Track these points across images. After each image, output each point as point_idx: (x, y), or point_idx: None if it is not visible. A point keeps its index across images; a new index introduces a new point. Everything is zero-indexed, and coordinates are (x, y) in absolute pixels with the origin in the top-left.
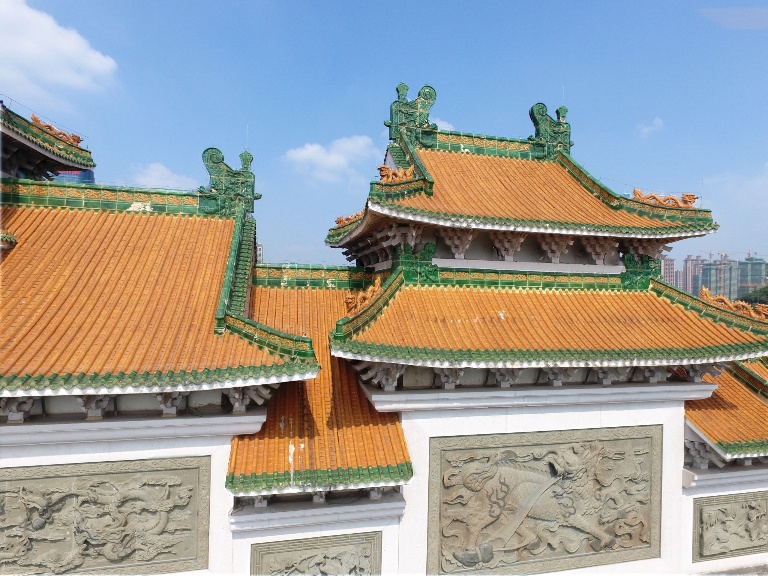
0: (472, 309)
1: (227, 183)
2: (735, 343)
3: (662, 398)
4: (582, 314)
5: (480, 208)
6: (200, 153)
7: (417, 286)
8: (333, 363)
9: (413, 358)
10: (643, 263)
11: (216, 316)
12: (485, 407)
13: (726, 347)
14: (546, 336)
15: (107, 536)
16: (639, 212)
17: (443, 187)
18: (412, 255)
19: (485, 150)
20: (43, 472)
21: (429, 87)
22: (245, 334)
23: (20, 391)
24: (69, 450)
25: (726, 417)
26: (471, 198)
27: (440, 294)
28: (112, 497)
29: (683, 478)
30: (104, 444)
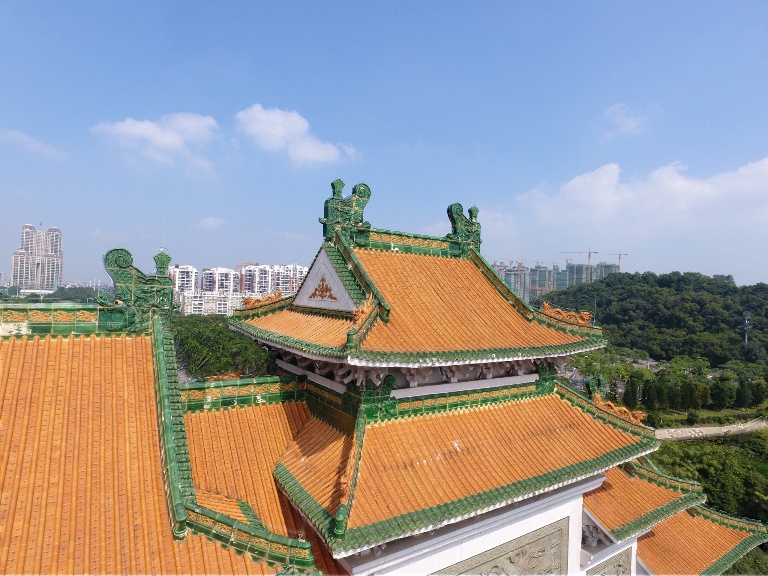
0: (432, 444)
1: (137, 292)
2: (623, 446)
3: (572, 496)
4: (516, 431)
5: (433, 335)
6: (100, 254)
7: (378, 422)
8: (284, 511)
9: (404, 532)
10: (551, 370)
11: (178, 519)
12: (447, 544)
13: (619, 452)
14: (497, 466)
15: None
16: (548, 324)
17: (391, 305)
18: (374, 391)
19: (412, 249)
20: None
21: (364, 185)
22: (216, 535)
23: None
24: None
25: (608, 499)
26: (420, 320)
27: (399, 428)
28: None
29: (581, 558)
30: None
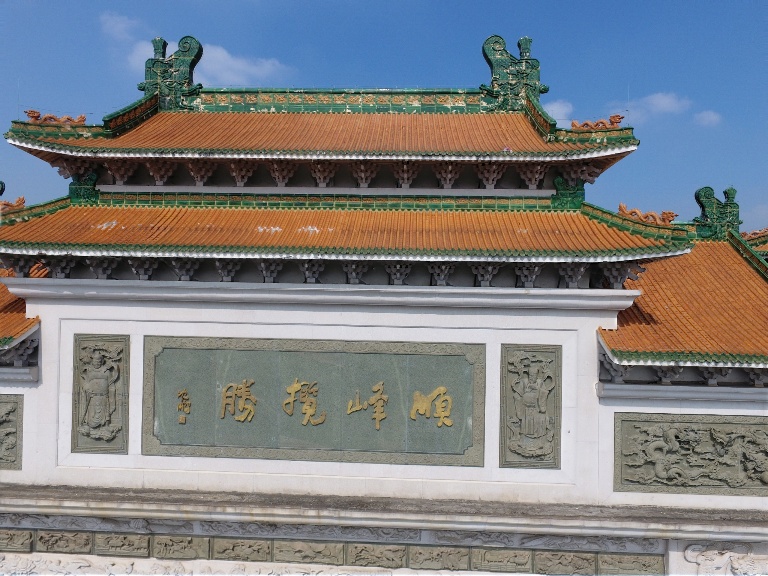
0: None
1: (718, 213)
2: None
3: None
4: None
5: None
6: (694, 191)
7: None
8: None
9: None
10: None
11: None
12: None
13: None
14: None
15: (766, 466)
16: None
17: None
18: None
19: None
20: (722, 419)
21: None
22: None
23: (761, 364)
24: (739, 406)
25: None
26: None
27: None
28: (765, 440)
29: None
30: (760, 404)
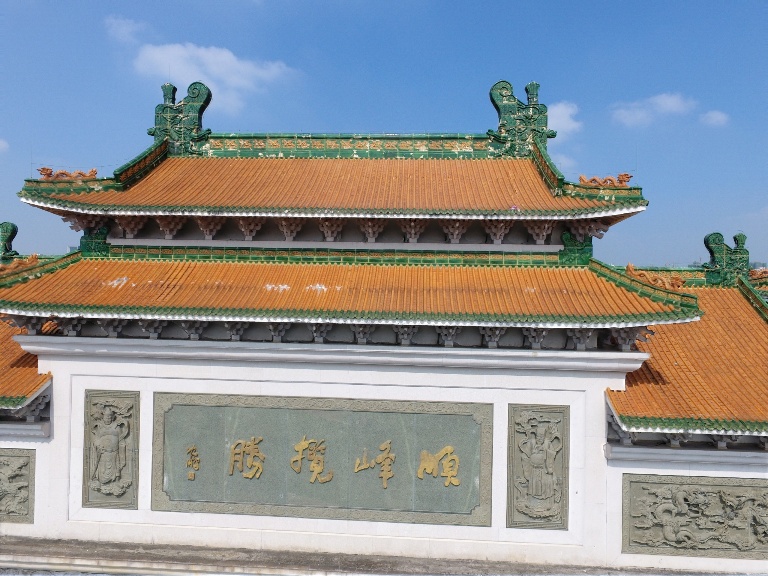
0: None
1: (727, 260)
2: None
3: None
4: None
5: None
6: (703, 237)
7: None
8: None
9: None
10: None
11: None
12: None
13: None
14: None
15: None
16: None
17: None
18: None
19: None
20: (732, 482)
21: None
22: None
23: None
24: (749, 469)
25: None
26: None
27: None
28: None
29: None
30: None
